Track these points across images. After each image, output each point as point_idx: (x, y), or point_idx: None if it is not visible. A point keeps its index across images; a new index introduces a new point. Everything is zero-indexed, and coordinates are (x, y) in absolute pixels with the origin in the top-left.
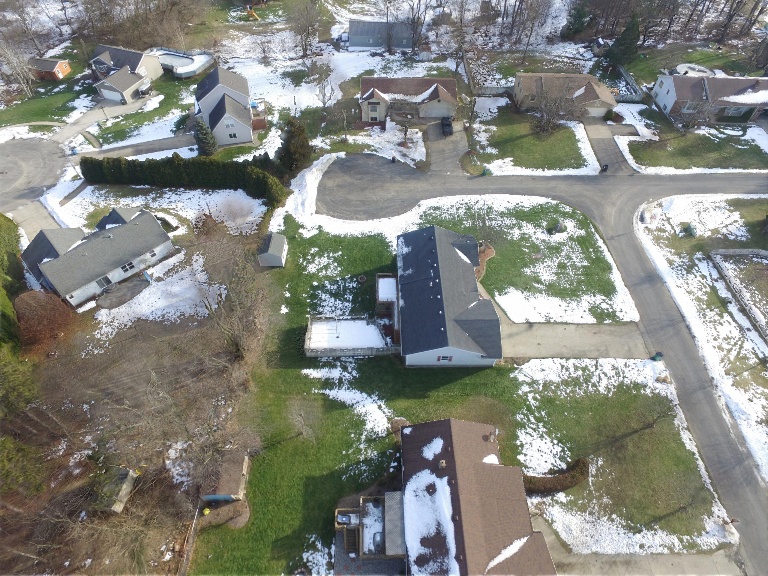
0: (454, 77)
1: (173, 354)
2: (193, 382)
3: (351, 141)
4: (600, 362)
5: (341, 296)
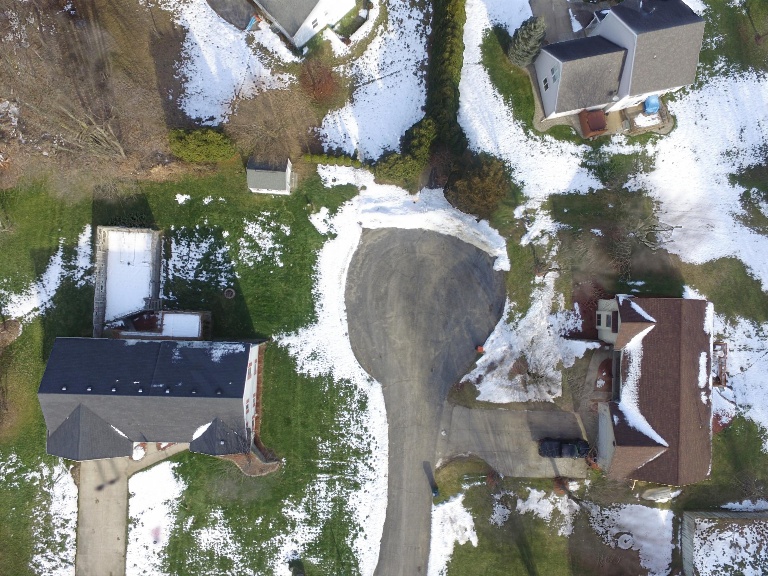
0: (745, 484)
1: (128, 81)
2: (86, 109)
3: (539, 280)
4: (70, 567)
5: (205, 267)
